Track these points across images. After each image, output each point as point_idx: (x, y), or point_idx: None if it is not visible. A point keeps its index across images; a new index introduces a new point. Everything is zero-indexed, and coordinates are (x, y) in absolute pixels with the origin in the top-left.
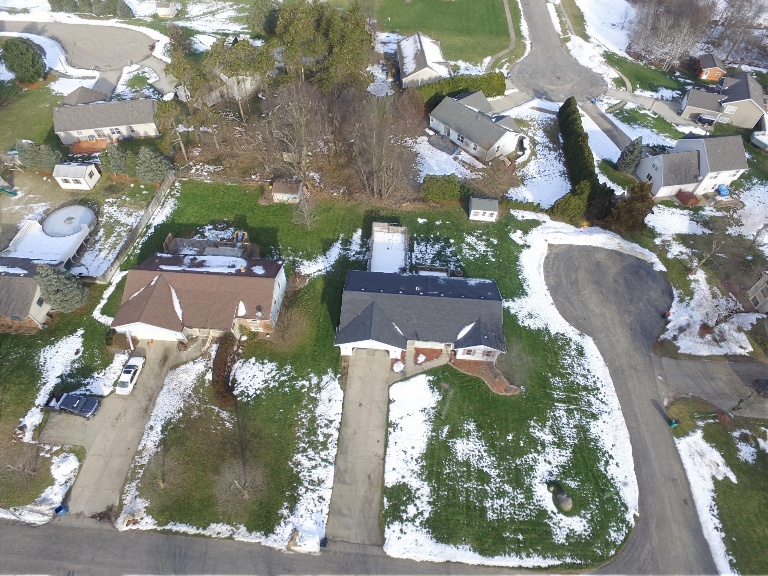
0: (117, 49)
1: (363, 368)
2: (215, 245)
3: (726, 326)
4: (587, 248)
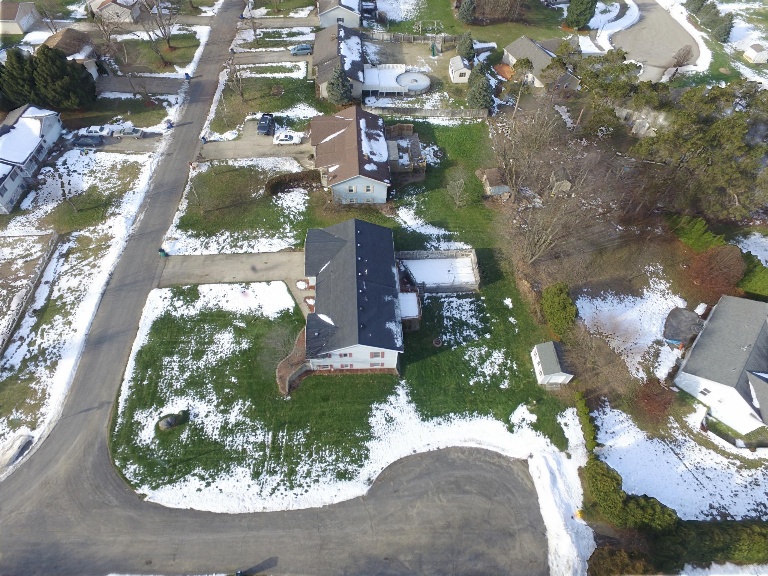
0: (657, 49)
1: (299, 261)
2: (407, 150)
3: None
4: (537, 521)
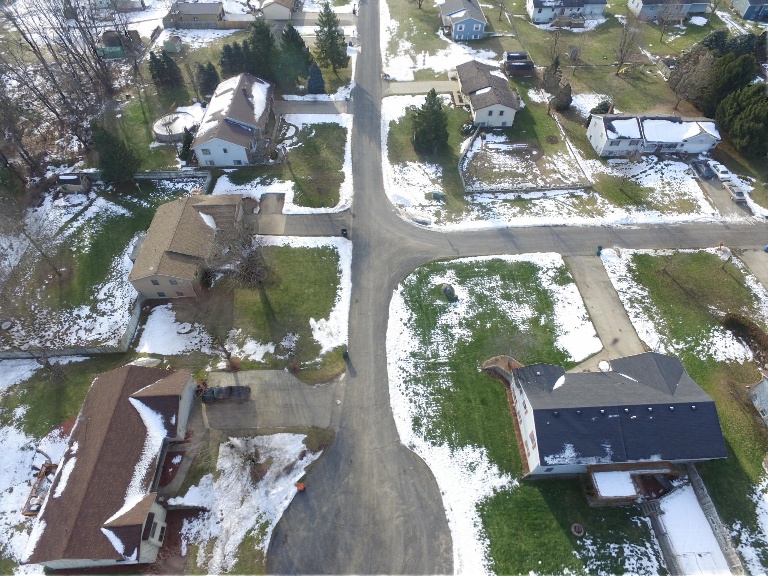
0: None
1: None
2: None
3: (231, 480)
4: None
